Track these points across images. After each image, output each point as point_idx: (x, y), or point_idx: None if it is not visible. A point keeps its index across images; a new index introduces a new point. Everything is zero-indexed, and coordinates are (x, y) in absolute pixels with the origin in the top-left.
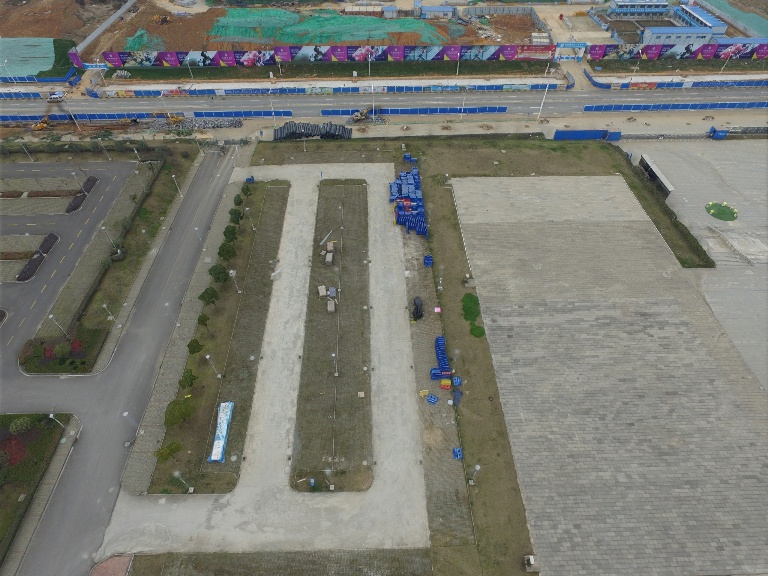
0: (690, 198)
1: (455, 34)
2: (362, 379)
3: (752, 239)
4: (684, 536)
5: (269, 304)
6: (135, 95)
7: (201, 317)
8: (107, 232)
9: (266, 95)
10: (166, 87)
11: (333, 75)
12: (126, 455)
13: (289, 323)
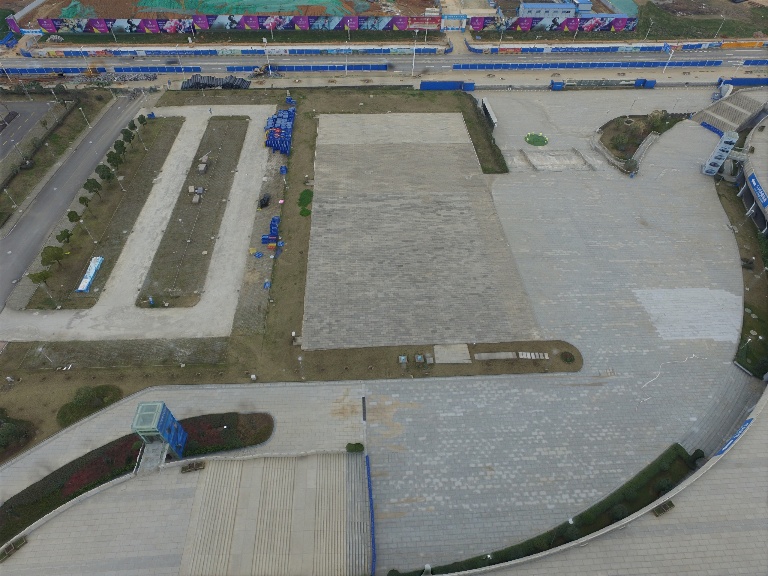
0: (515, 131)
1: (360, 9)
2: (208, 244)
3: (549, 157)
4: (412, 325)
5: (147, 198)
6: (65, 55)
7: (82, 197)
8: (20, 150)
9: (182, 56)
10: (94, 50)
11: (246, 41)
12: (12, 288)
13: (160, 210)
